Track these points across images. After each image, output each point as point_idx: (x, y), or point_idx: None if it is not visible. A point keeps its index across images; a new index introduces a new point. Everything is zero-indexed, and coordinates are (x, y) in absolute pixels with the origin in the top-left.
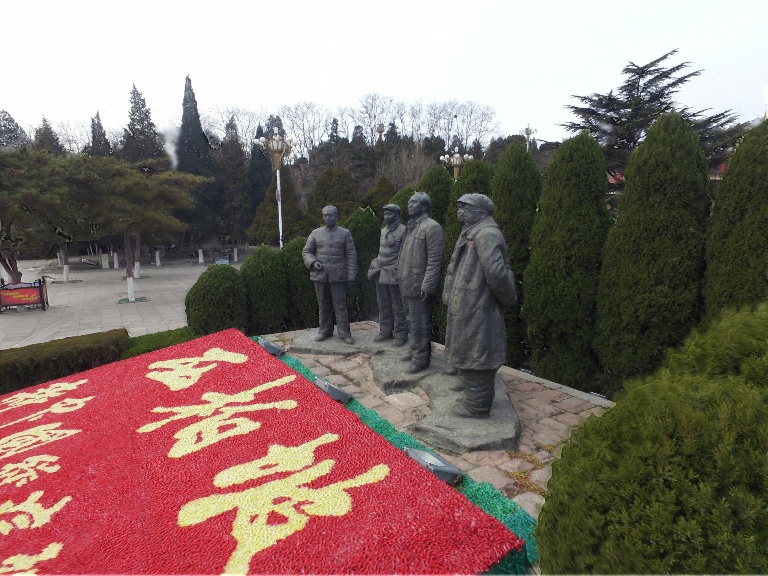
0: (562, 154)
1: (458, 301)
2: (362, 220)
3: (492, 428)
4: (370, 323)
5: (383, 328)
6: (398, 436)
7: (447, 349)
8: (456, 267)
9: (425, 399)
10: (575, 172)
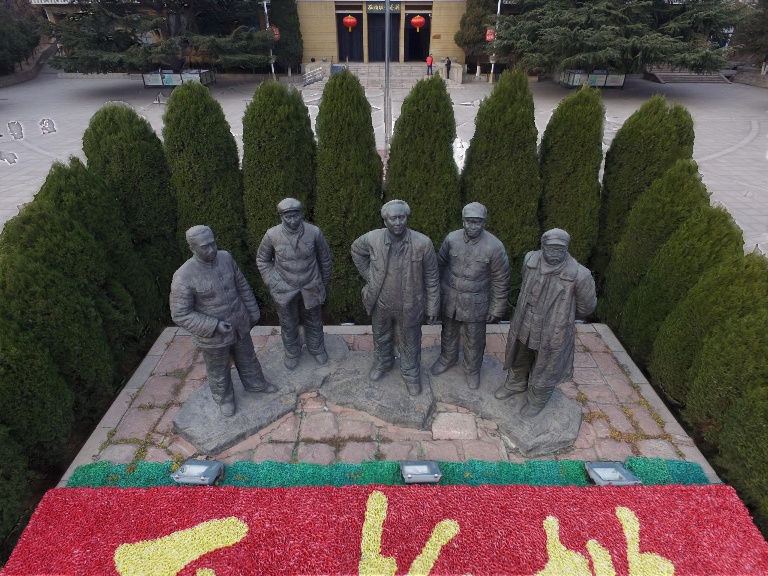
0: (427, 102)
1: (561, 337)
2: (82, 184)
3: (563, 410)
4: (181, 333)
5: (294, 350)
6: (534, 469)
7: (539, 376)
8: (551, 307)
9: (465, 412)
10: (443, 124)
